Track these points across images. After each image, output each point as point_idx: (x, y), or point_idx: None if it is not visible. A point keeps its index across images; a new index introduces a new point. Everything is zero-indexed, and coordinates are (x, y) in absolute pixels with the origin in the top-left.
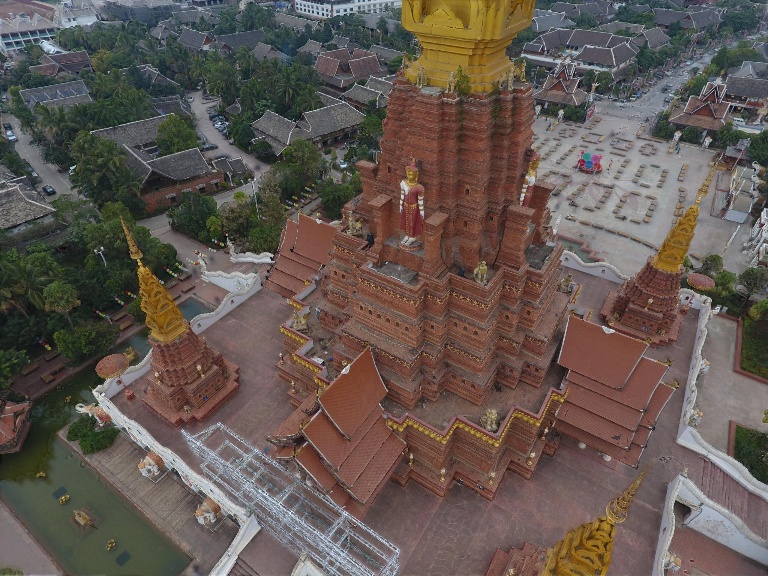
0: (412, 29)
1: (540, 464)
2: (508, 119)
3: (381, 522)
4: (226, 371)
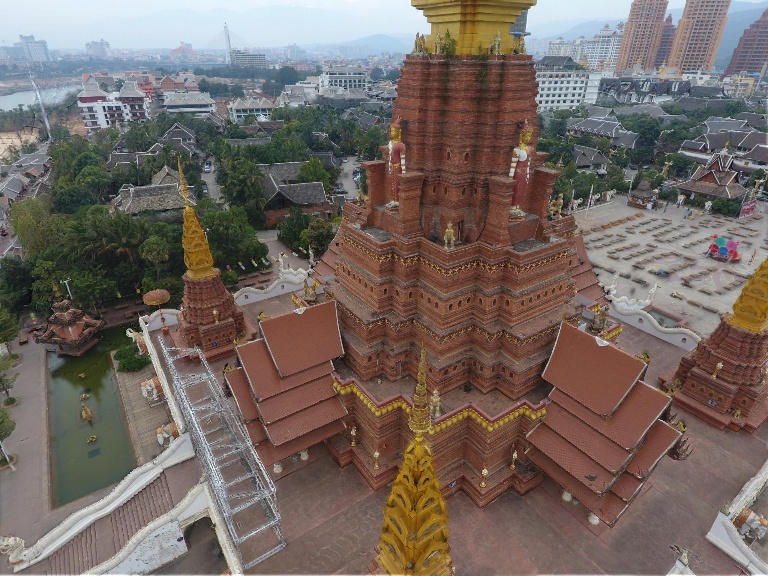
0: (415, 3)
1: (503, 498)
2: (494, 84)
3: (301, 490)
4: None
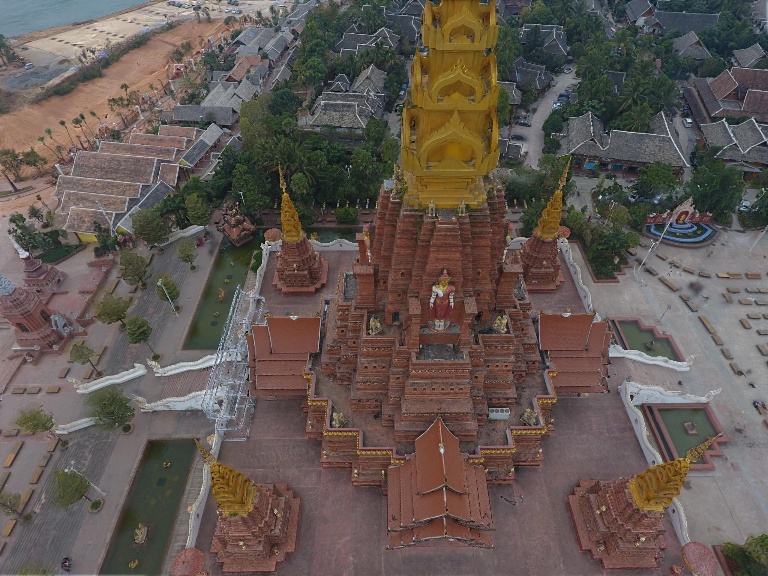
0: None
1: (371, 489)
2: (424, 235)
3: (275, 413)
4: (318, 280)
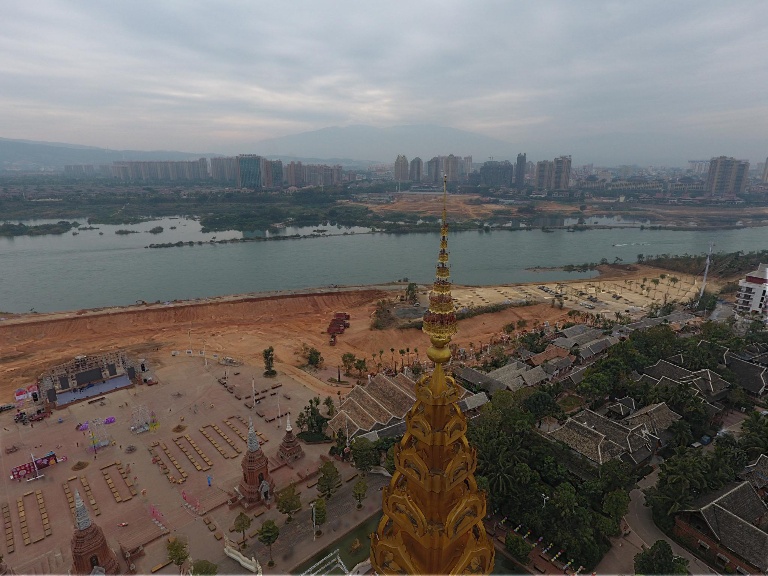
0: None
1: None
2: None
3: None
4: None
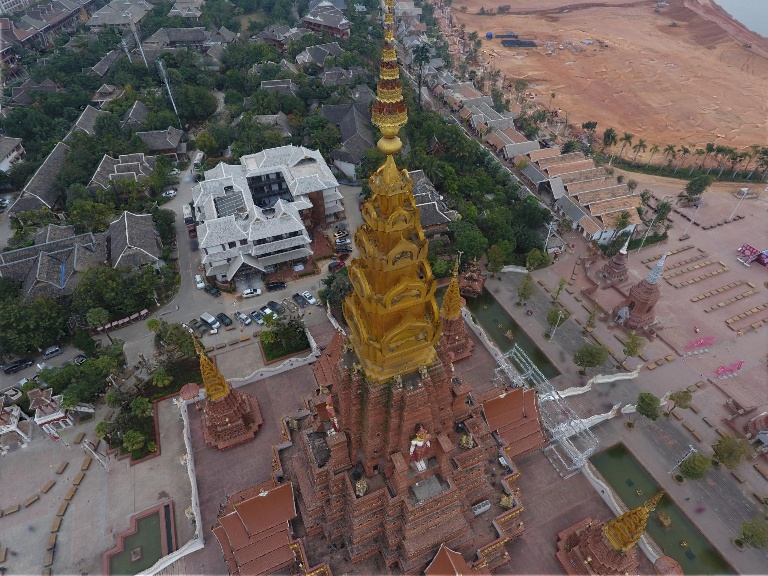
0: None
1: None
2: None
3: None
4: None
